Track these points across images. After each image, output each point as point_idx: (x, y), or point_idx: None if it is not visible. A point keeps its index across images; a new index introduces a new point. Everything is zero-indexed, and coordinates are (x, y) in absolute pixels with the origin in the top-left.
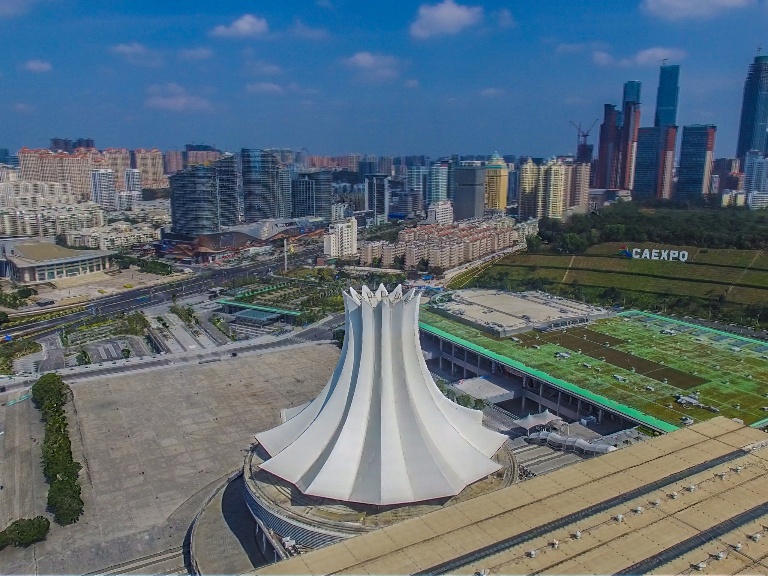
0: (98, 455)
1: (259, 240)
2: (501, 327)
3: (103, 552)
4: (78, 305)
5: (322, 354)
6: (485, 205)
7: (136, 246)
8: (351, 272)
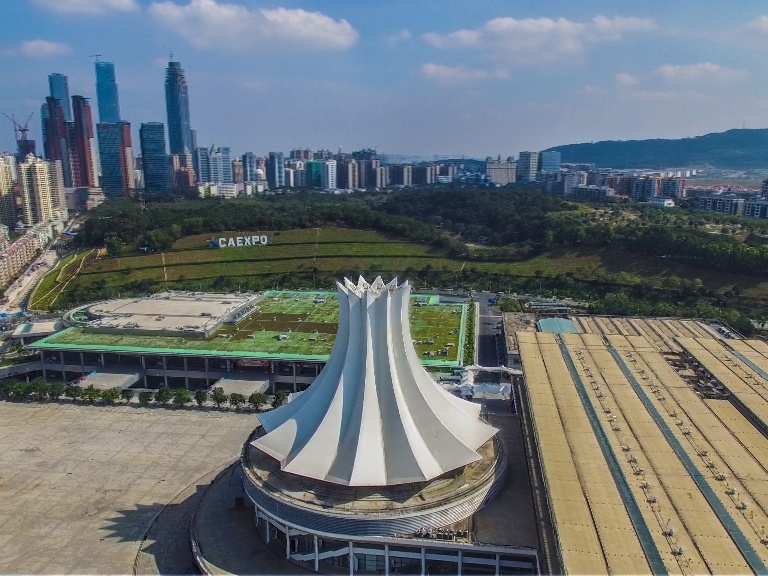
0: None
1: None
2: (198, 328)
3: None
4: None
5: (4, 415)
6: None
7: None
8: None
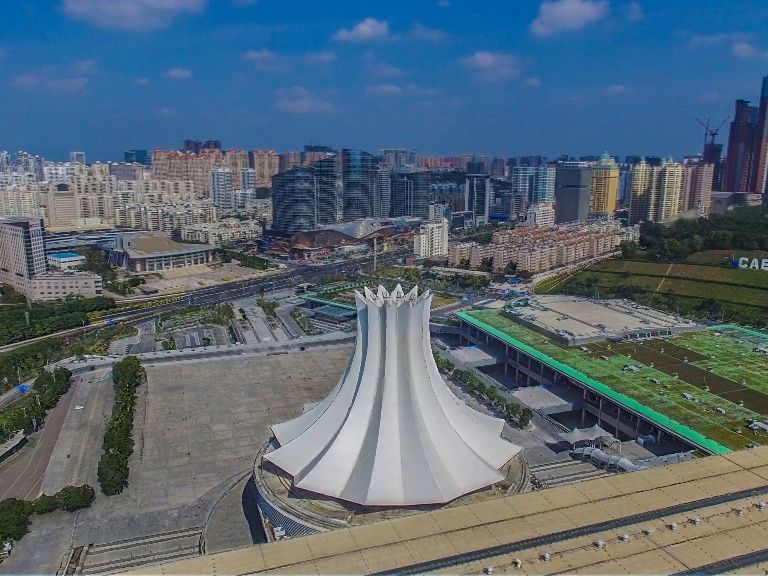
0: (155, 434)
1: (354, 239)
2: (571, 335)
3: (134, 524)
4: (178, 295)
5: None
6: (590, 208)
7: (241, 241)
8: (438, 273)
